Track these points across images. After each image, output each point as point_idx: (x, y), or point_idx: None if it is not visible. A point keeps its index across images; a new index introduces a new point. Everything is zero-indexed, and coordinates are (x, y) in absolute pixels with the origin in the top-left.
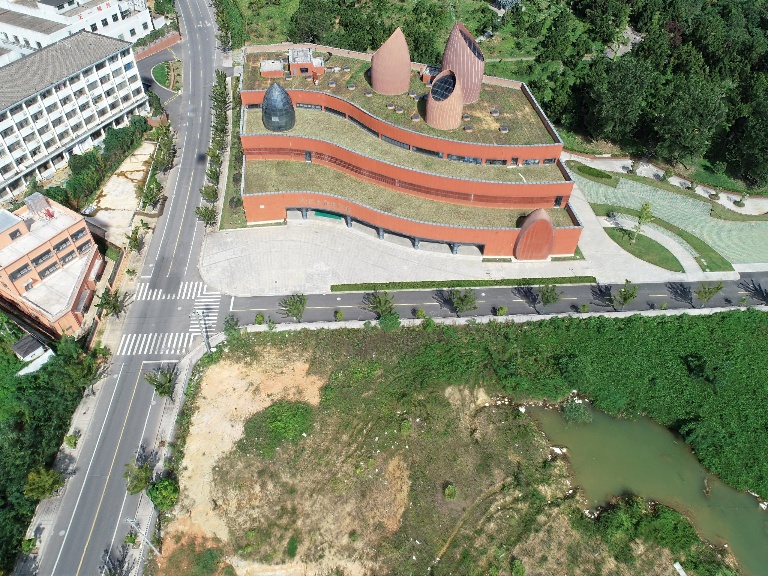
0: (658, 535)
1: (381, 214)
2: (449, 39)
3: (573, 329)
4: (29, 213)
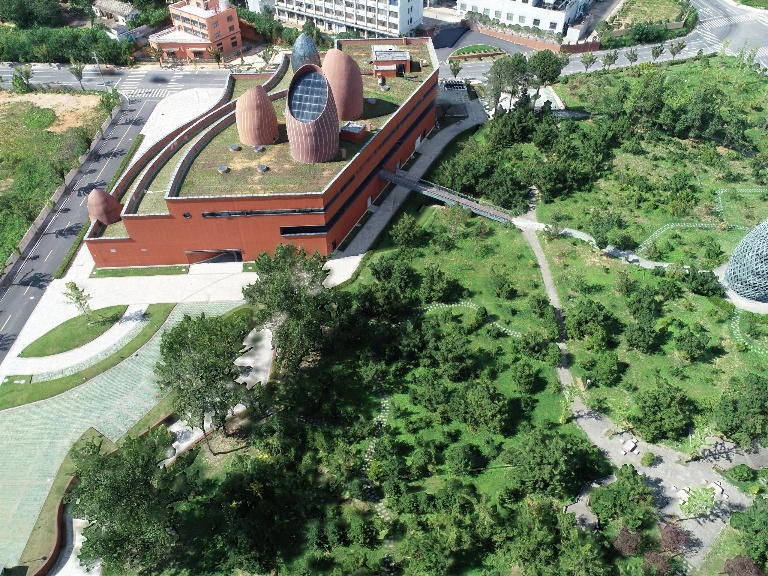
0: None
1: None
2: None
3: (7, 245)
4: None
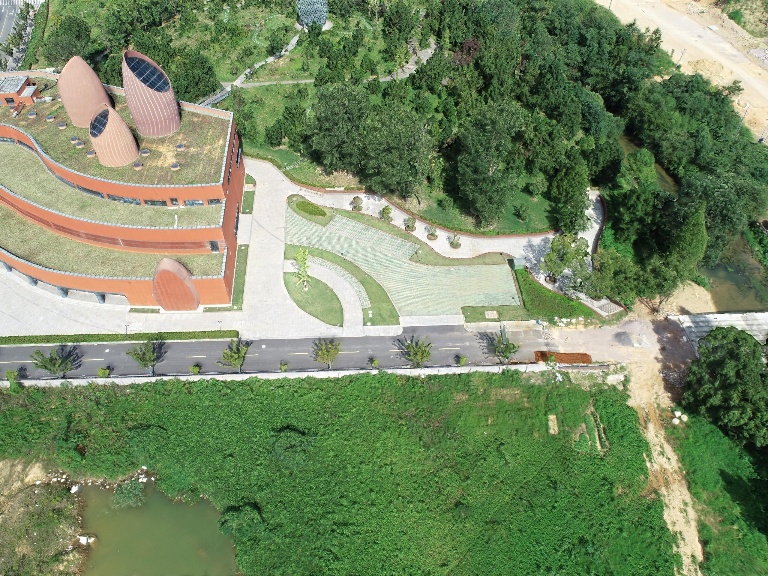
0: None
1: (16, 261)
2: None
3: (173, 394)
4: None
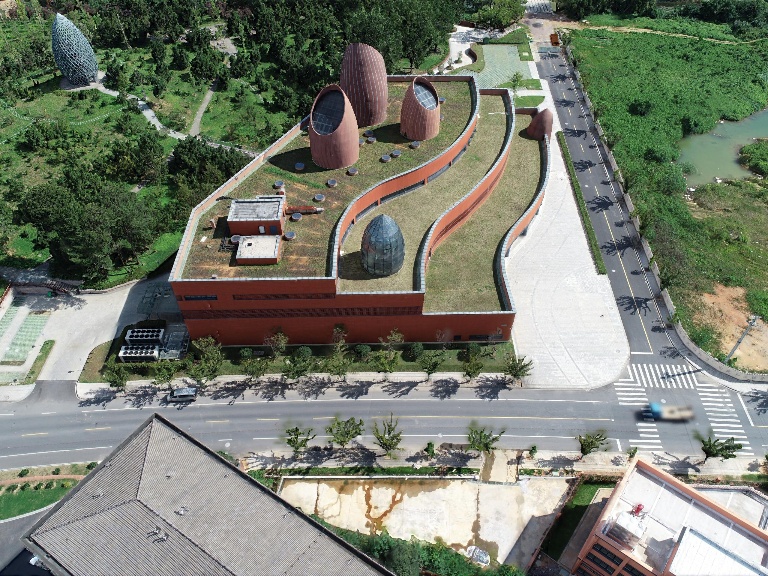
0: (766, 155)
1: None
2: (364, 63)
3: None
4: (632, 554)
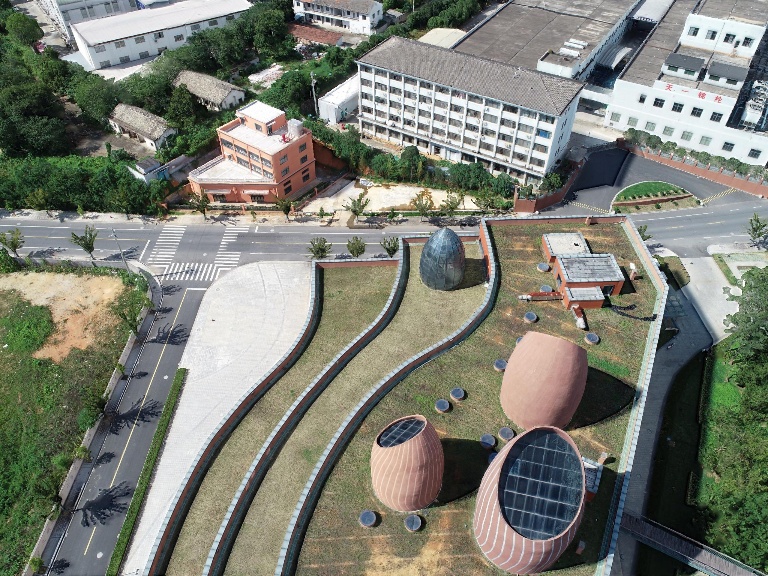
0: None
1: None
2: None
3: None
4: None
